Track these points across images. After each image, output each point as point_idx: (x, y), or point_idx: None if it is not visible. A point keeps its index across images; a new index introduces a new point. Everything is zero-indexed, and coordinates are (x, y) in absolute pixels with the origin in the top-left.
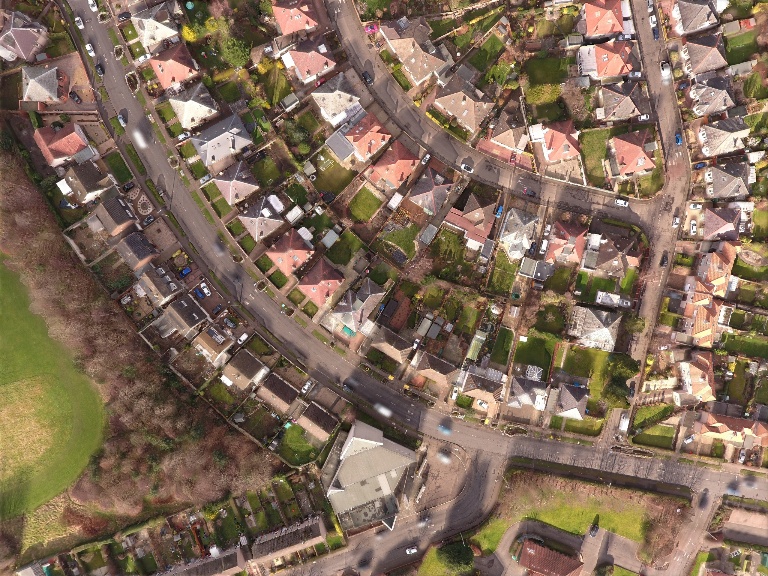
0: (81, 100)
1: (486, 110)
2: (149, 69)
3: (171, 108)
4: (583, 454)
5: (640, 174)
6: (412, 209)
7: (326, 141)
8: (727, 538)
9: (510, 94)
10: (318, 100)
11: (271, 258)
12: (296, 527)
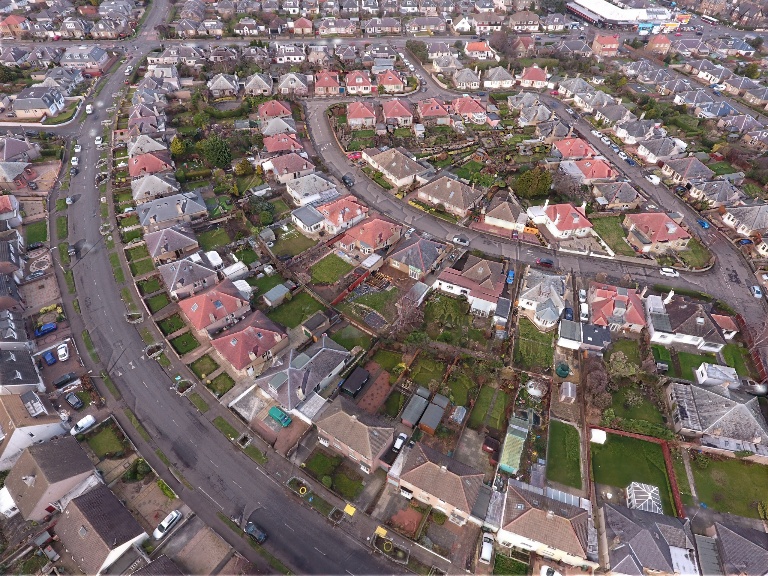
0: (37, 188)
1: (474, 195)
2: (125, 172)
3: (130, 194)
4: None
5: (676, 249)
6: (393, 274)
7: (293, 211)
8: None
9: (498, 190)
10: (291, 185)
11: (183, 308)
12: None
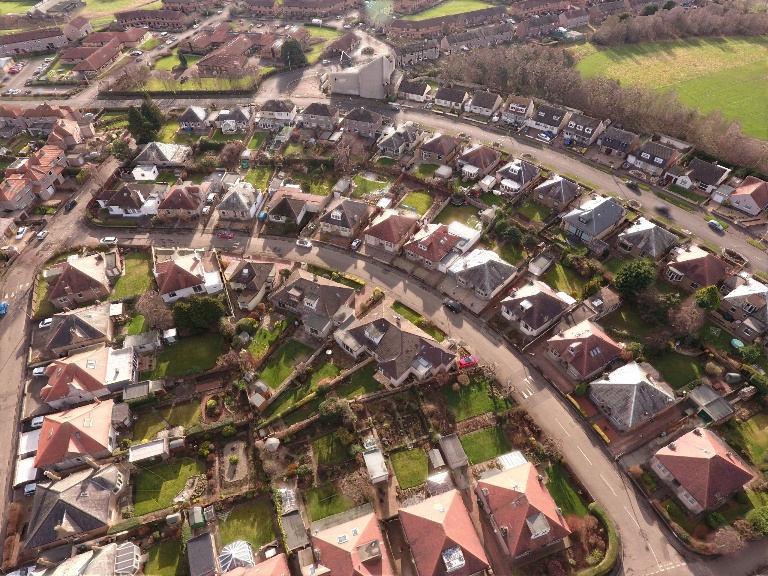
0: None
1: None
2: None
3: None
4: (188, 104)
5: None
6: None
7: None
8: (74, 86)
9: None
10: None
11: None
12: (413, 58)
